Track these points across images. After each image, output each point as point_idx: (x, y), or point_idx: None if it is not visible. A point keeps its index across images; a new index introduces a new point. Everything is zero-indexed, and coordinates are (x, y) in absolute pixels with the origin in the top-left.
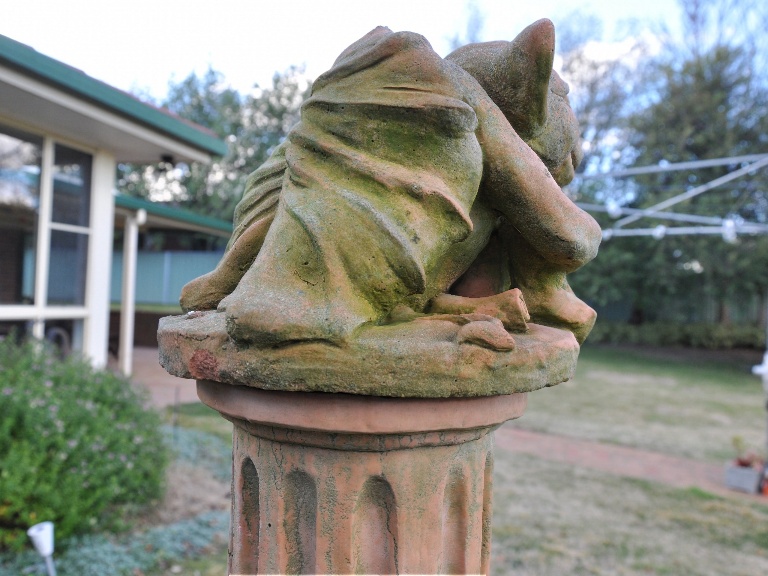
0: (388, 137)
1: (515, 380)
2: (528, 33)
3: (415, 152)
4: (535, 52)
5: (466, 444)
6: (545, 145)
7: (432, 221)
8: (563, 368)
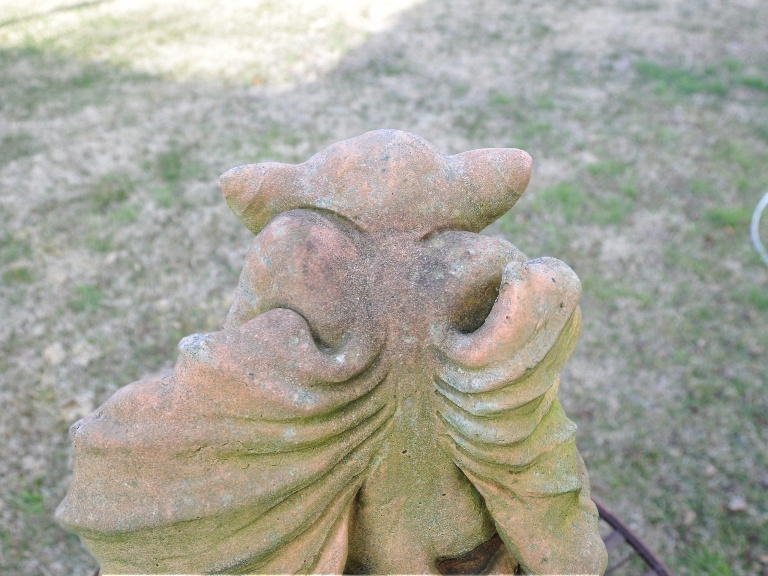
0: None
1: None
2: (525, 177)
3: None
4: None
5: None
6: None
7: None
8: None
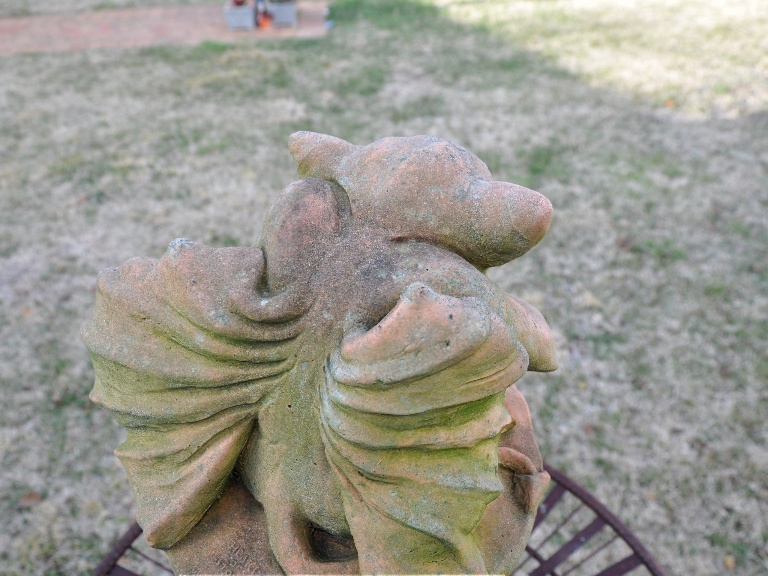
0: None
1: None
2: (534, 223)
3: None
4: None
5: None
6: None
7: None
8: None
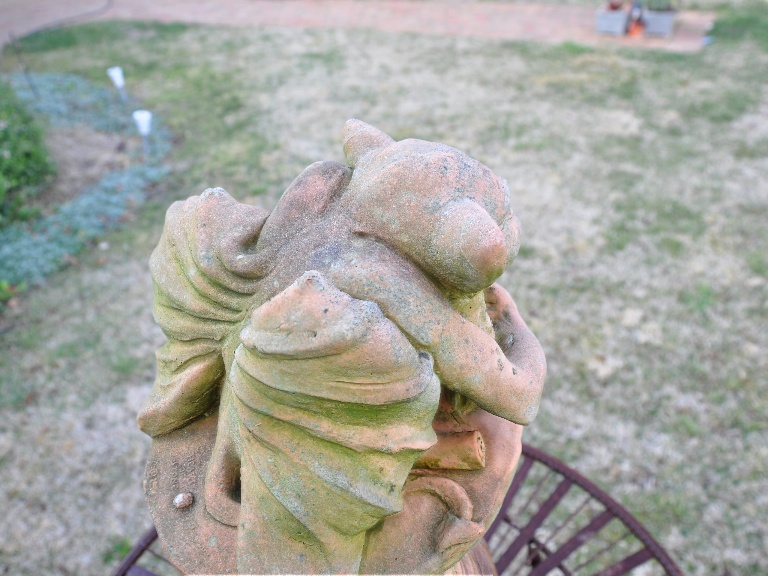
0: (348, 411)
1: None
2: (477, 252)
3: (378, 417)
4: (486, 271)
5: None
6: None
7: (403, 463)
8: None
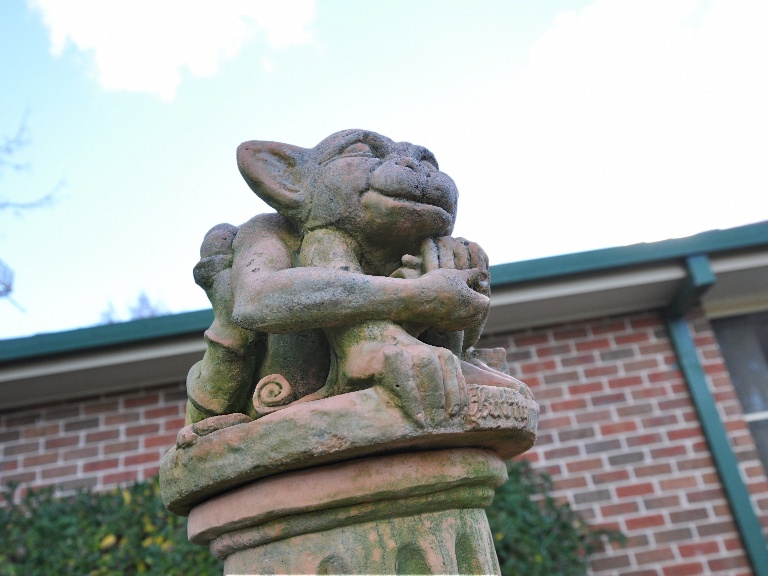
0: None
1: (207, 470)
2: None
3: None
4: None
5: (273, 545)
6: (320, 216)
7: None
8: (278, 443)
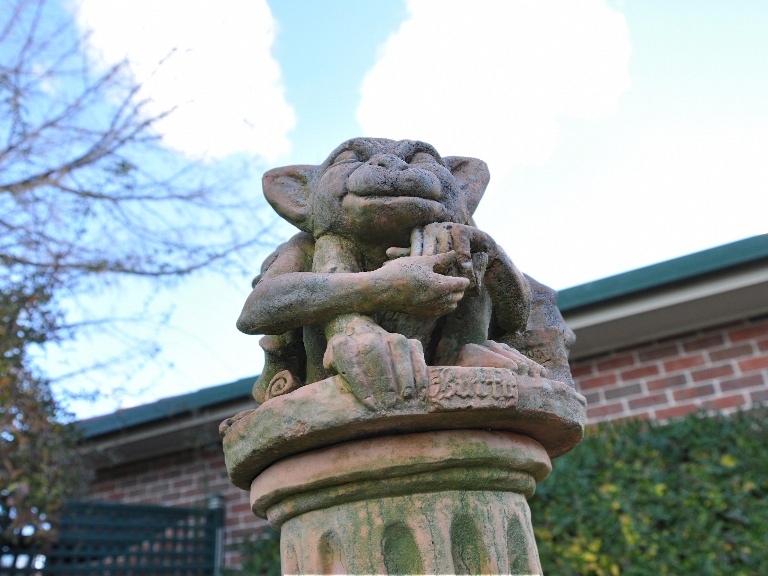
0: None
1: None
2: None
3: None
4: None
5: None
6: None
7: None
8: (263, 429)
